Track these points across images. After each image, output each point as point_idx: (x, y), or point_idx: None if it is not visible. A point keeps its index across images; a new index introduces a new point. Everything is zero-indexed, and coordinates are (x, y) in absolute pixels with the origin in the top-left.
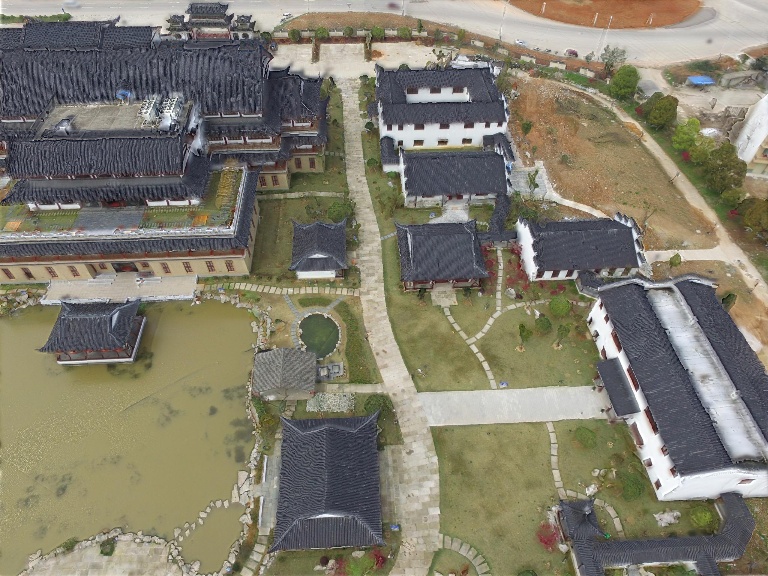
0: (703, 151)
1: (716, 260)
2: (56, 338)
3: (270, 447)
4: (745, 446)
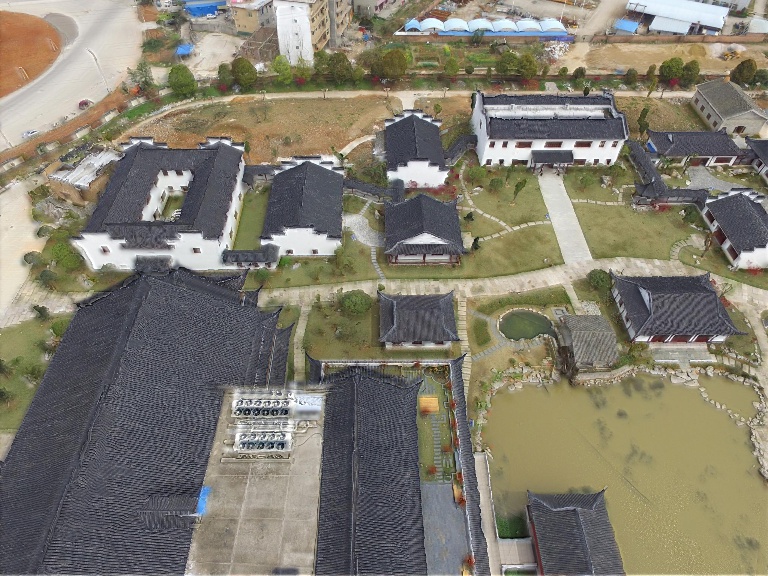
0: (307, 69)
1: (415, 102)
2: None
3: None
4: (597, 114)
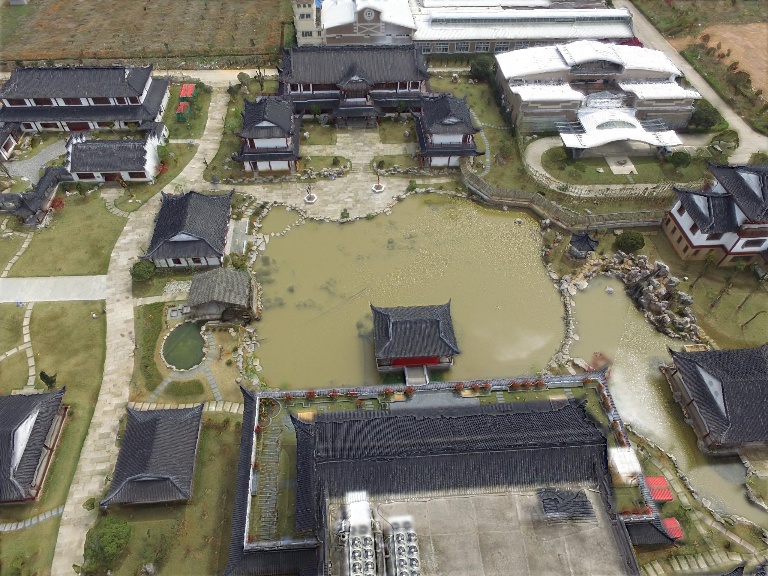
0: None
1: None
2: (439, 311)
3: None
4: None
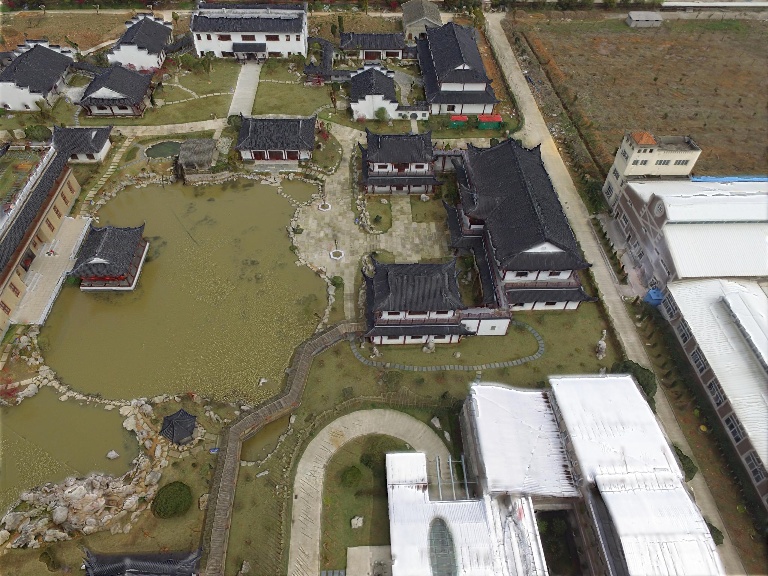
0: None
1: None
2: (116, 265)
3: (248, 170)
4: (292, 17)
